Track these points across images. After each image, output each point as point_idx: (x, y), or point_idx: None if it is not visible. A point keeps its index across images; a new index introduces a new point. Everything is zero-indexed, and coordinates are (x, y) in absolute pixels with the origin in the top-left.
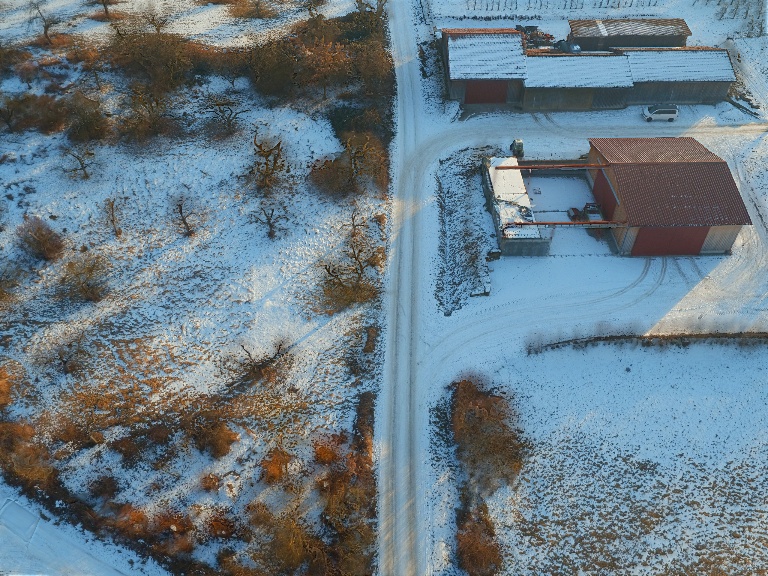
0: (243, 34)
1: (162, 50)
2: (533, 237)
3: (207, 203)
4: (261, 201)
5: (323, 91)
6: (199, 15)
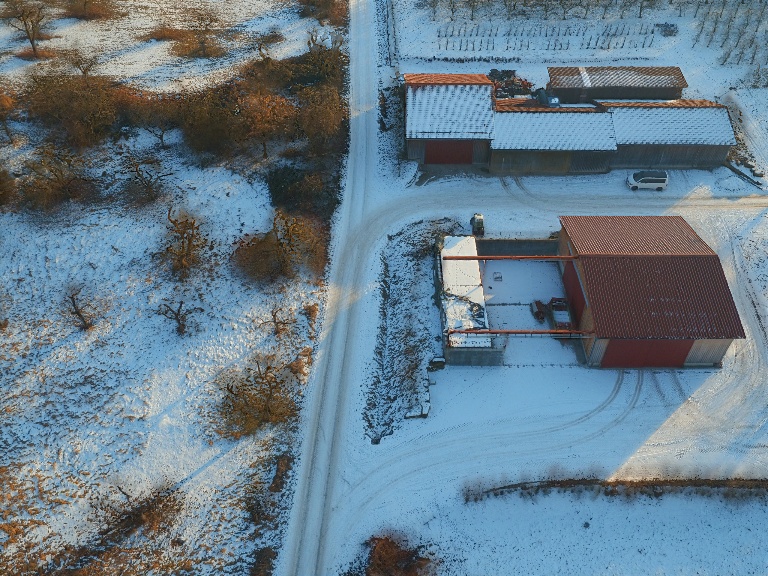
0: (184, 77)
1: (75, 104)
2: (483, 346)
3: (113, 287)
4: (175, 286)
5: None
6: (138, 54)
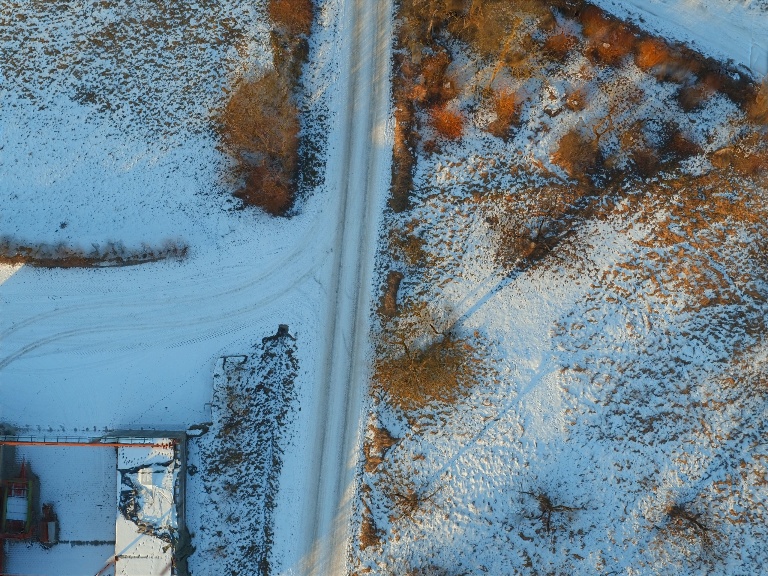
0: None
1: None
2: None
3: None
4: None
5: None
6: None
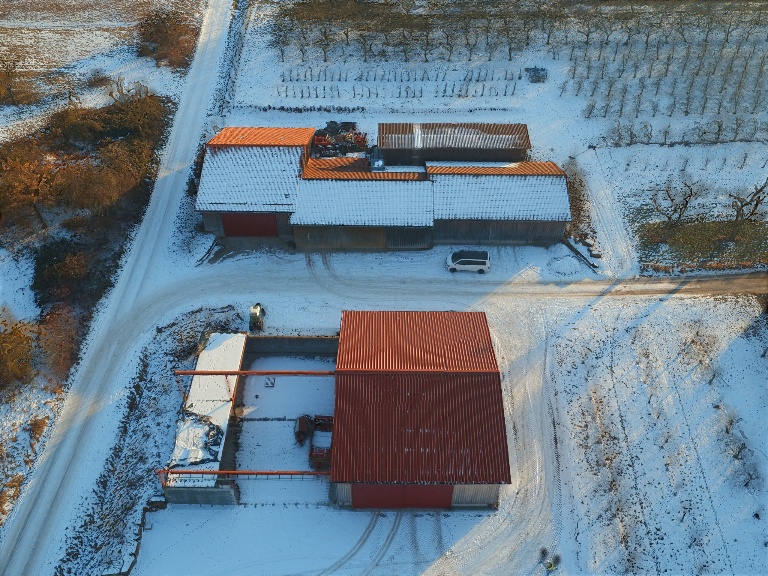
0: None
1: None
2: (204, 485)
3: None
4: None
5: (47, 215)
6: None
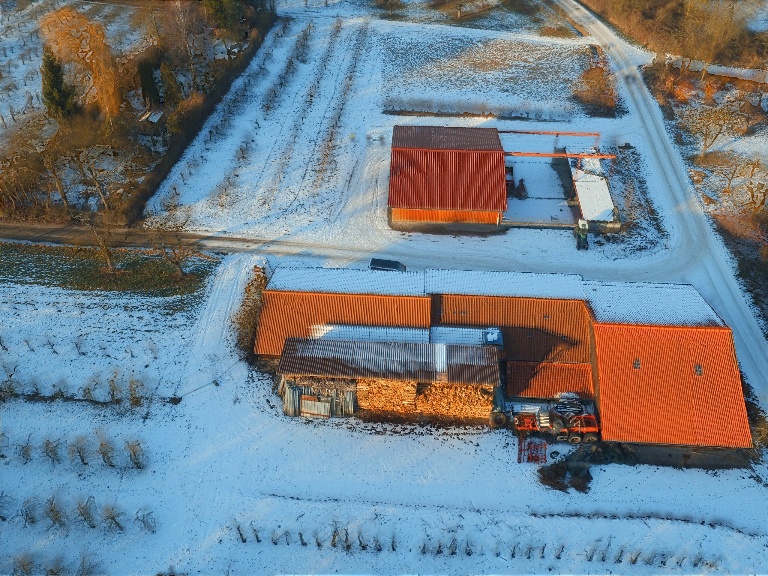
0: None
1: None
2: (571, 146)
3: None
4: None
5: None
6: None
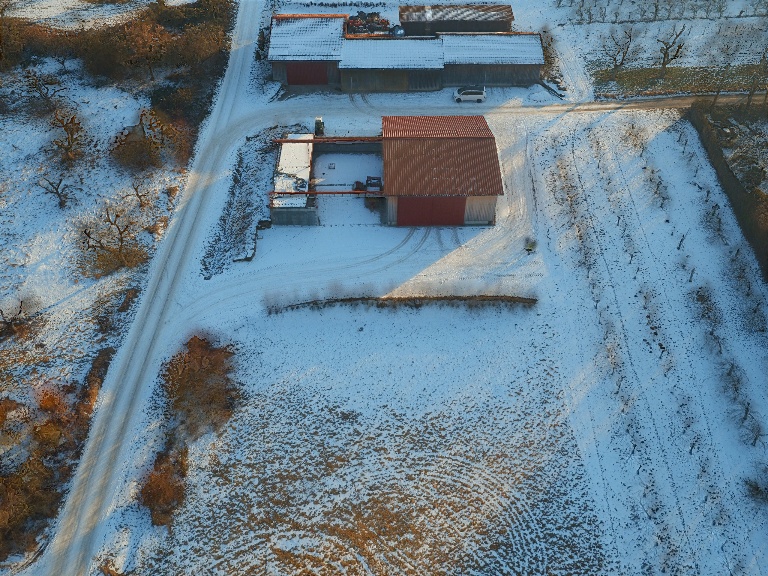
0: (91, 18)
1: None
2: (298, 206)
3: (10, 175)
4: (61, 173)
5: (153, 72)
6: (53, 0)
